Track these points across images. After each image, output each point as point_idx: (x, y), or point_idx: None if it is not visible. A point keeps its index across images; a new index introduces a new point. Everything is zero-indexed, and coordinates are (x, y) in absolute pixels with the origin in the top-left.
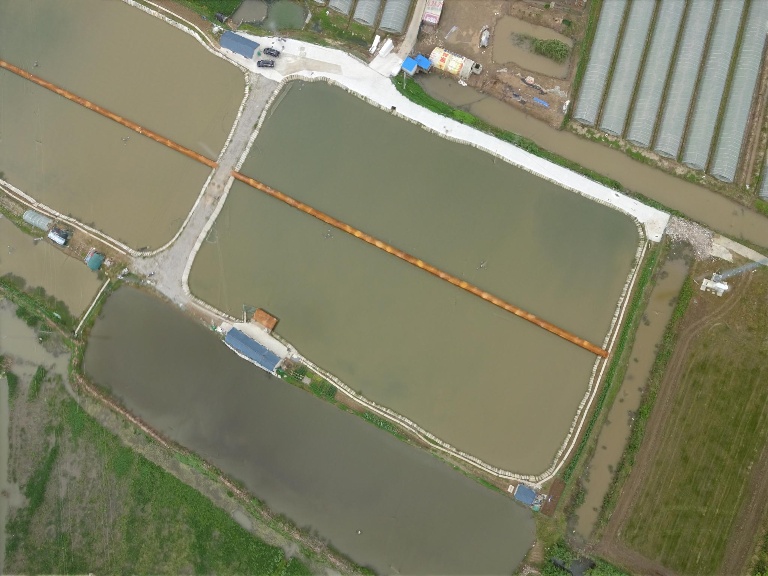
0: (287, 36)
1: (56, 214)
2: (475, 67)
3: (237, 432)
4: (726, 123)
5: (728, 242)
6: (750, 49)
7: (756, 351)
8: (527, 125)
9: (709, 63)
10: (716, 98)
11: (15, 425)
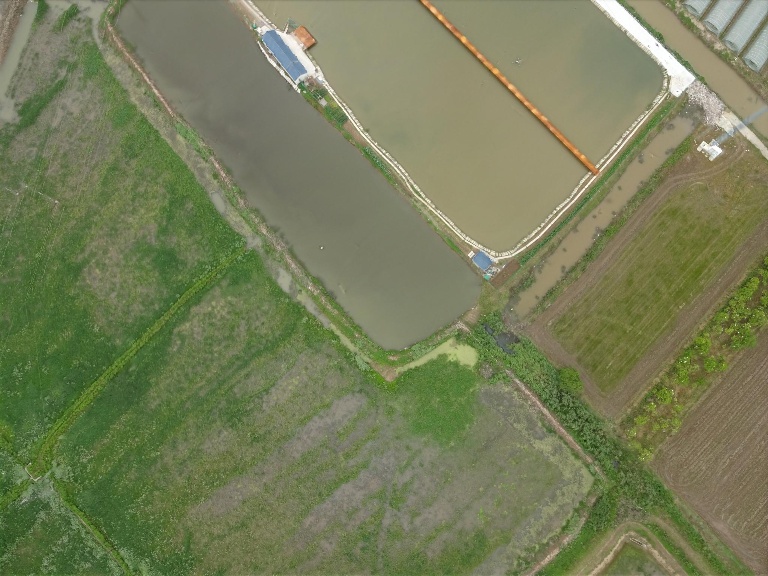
0: None
1: None
2: None
3: (241, 126)
4: None
5: (735, 119)
6: None
7: (723, 215)
8: None
9: None
10: None
11: (31, 48)
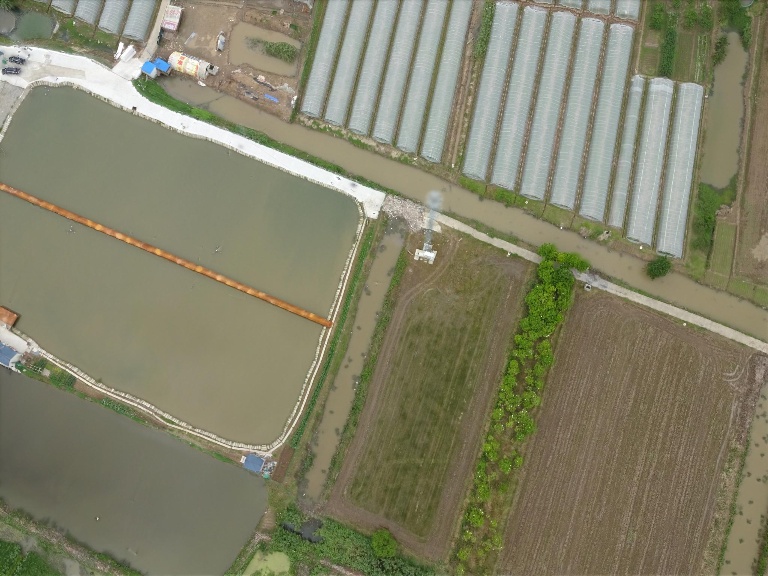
0: (34, 45)
1: None
2: (209, 68)
3: None
4: (432, 110)
5: (437, 215)
6: (450, 46)
7: (463, 311)
8: (260, 120)
9: (417, 59)
10: (423, 89)
11: None
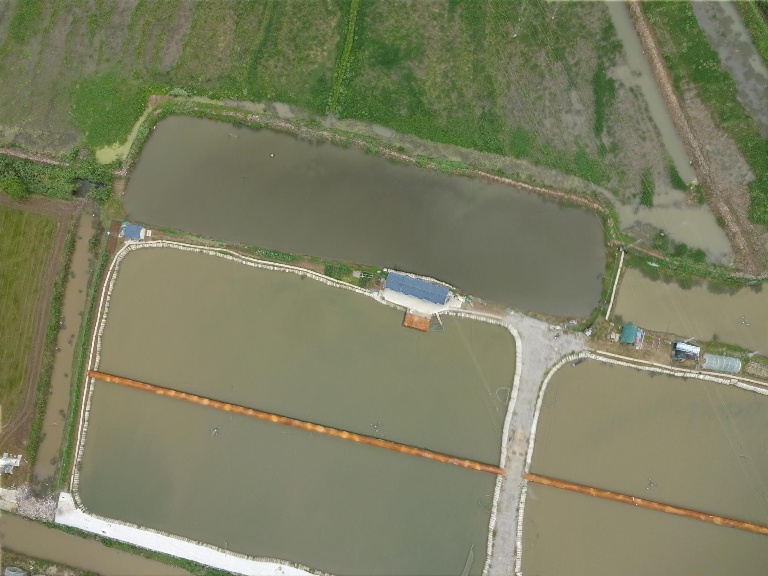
0: None
1: (703, 376)
2: None
3: (413, 206)
4: None
5: (4, 506)
6: None
7: None
8: None
9: None
10: None
11: (655, 141)
